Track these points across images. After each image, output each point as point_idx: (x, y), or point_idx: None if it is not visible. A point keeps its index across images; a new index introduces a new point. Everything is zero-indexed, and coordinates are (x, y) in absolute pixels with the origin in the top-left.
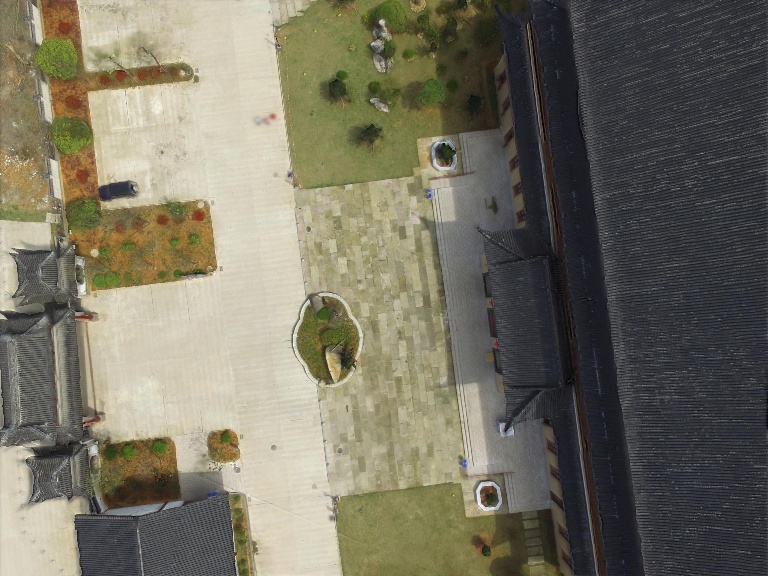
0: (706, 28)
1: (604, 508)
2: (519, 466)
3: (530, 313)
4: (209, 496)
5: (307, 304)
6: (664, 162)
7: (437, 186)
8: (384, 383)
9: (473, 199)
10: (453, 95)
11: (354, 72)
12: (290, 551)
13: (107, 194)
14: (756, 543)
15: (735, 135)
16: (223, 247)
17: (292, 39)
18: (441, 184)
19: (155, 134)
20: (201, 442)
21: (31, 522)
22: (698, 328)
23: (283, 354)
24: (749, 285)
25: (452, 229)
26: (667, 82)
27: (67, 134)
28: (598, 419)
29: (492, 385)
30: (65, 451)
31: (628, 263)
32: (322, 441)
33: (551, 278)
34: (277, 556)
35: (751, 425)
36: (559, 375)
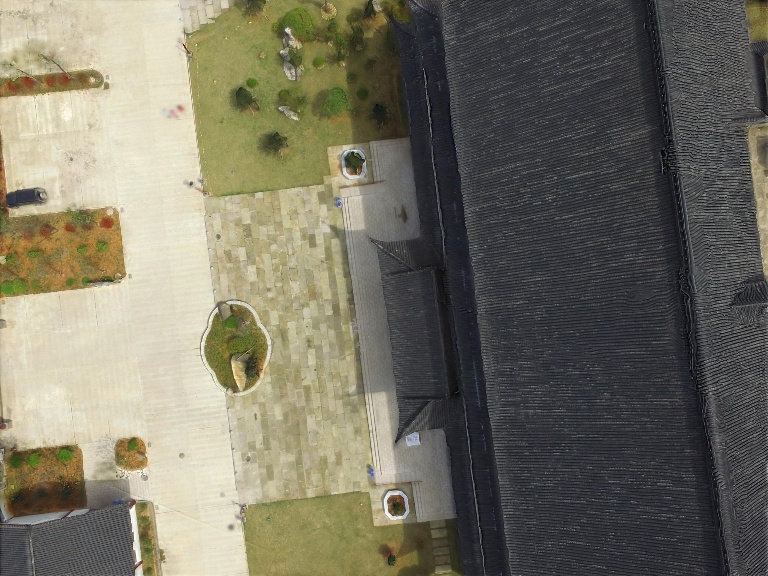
0: (563, 43)
1: (483, 520)
2: (427, 475)
3: (420, 324)
4: (114, 504)
5: (215, 312)
6: (527, 176)
7: (347, 194)
8: (293, 391)
9: (383, 208)
10: (363, 103)
11: (264, 80)
12: (197, 559)
13: (14, 201)
14: (611, 558)
15: (589, 150)
16: (132, 254)
17: (203, 46)
18: (351, 192)
19: (64, 141)
20: (108, 450)
21: None
22: (558, 342)
23: (192, 362)
24: (603, 300)
25: (361, 238)
26: (529, 96)
27: None
28: (478, 431)
29: None
30: None
31: (496, 276)
32: (230, 449)
33: (437, 289)
34: (184, 564)
35: (606, 440)
36: (446, 386)
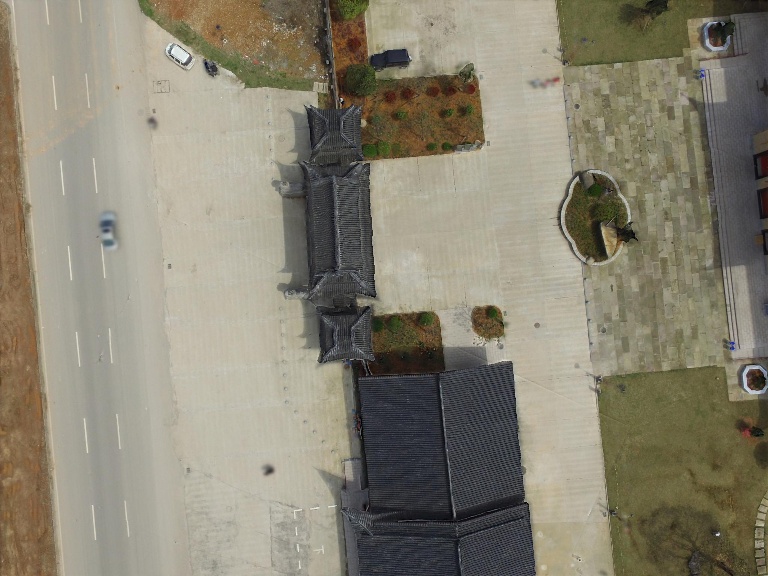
0: None
1: None
2: None
3: None
4: None
5: (576, 181)
6: None
7: (707, 67)
8: (649, 264)
9: (745, 80)
10: None
11: None
12: (551, 430)
13: (381, 62)
14: None
15: None
16: (491, 122)
17: None
18: (712, 65)
19: (425, 6)
20: (465, 317)
21: (292, 392)
22: None
23: (549, 231)
24: None
25: (723, 110)
26: None
27: None
28: None
29: (760, 268)
30: (351, 311)
31: None
32: (586, 320)
33: None
34: (538, 434)
35: None
36: None
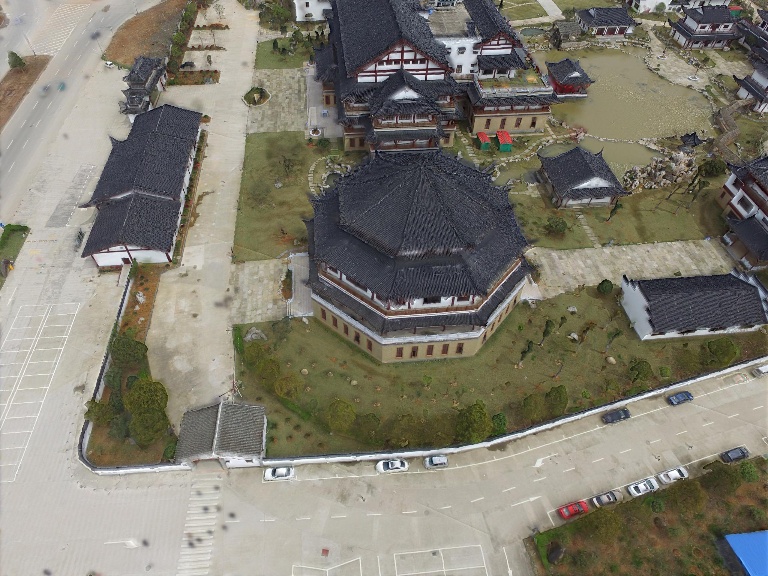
0: None
1: None
2: None
3: None
4: None
5: None
6: None
7: None
8: None
9: None
10: None
11: None
12: (223, 146)
13: None
14: None
15: None
16: (222, 79)
17: (263, 44)
18: None
19: None
20: None
21: None
22: None
23: None
24: None
25: (312, 76)
26: None
27: (177, 48)
28: None
29: (322, 107)
30: None
31: None
32: (247, 120)
33: None
34: (216, 147)
35: None
36: None
